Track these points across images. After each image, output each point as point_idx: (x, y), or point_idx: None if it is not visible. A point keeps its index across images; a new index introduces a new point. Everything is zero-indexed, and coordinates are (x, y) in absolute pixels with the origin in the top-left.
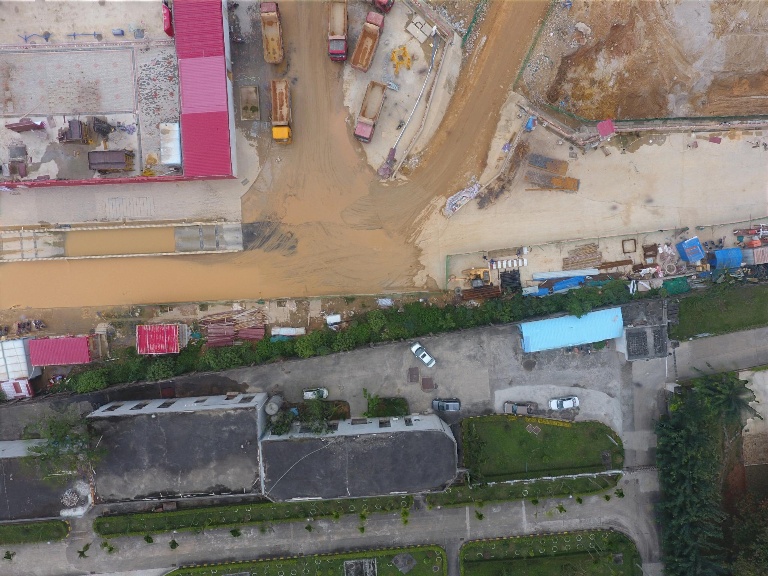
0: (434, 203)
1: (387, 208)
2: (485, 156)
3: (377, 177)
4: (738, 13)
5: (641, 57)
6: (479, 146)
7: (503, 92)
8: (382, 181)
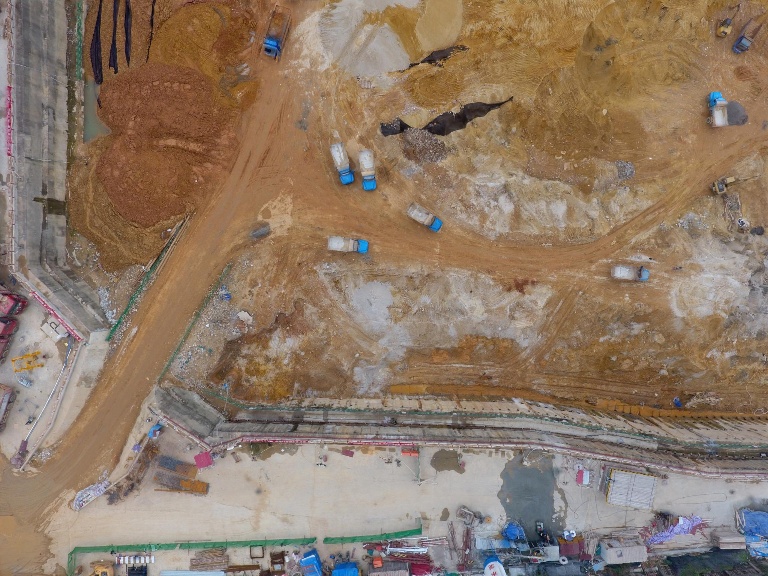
0: (63, 496)
1: (17, 497)
2: (120, 451)
3: (10, 465)
4: (420, 298)
5: (315, 339)
6: (116, 439)
7: (148, 384)
8: (14, 470)
